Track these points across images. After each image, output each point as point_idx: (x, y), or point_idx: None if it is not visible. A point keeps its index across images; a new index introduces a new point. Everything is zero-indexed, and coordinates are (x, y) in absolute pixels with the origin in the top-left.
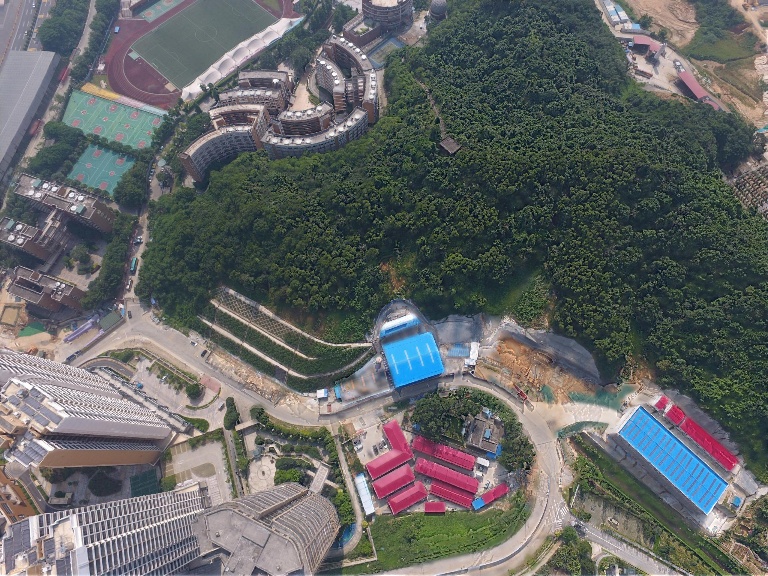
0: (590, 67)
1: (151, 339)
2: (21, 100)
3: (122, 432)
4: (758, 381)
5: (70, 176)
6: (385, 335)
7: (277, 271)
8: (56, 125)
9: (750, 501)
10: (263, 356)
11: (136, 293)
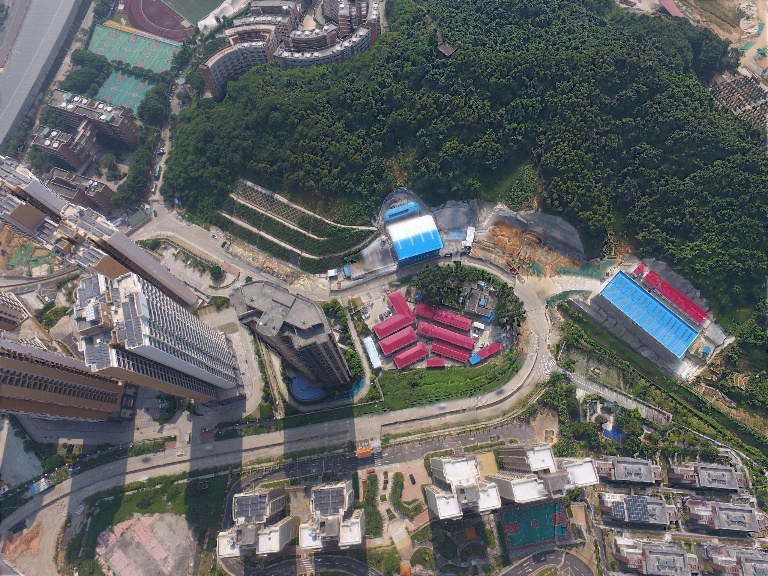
0: None
1: (175, 234)
2: (49, 33)
3: (159, 275)
4: (724, 239)
5: (97, 97)
6: (389, 219)
7: (291, 157)
8: (83, 52)
9: (719, 350)
10: (278, 242)
11: (161, 193)
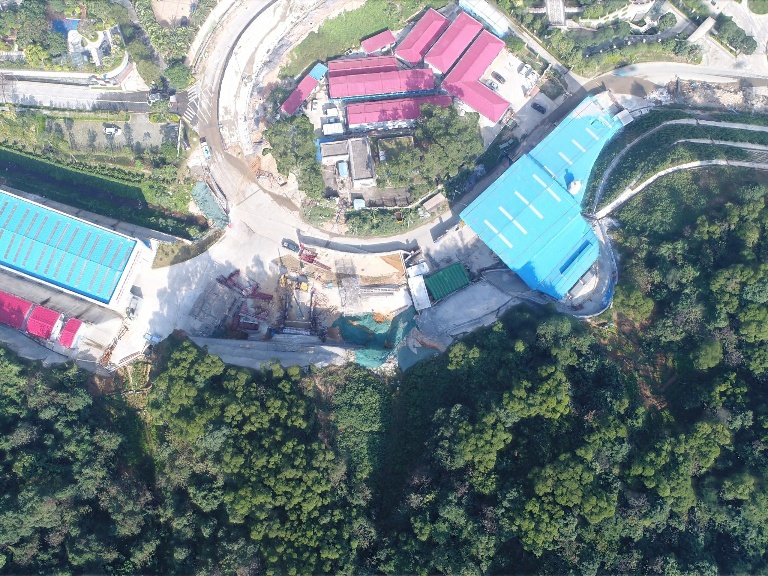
0: None
1: None
2: None
3: None
4: None
5: None
6: (587, 237)
7: None
8: None
9: None
10: (751, 127)
11: None
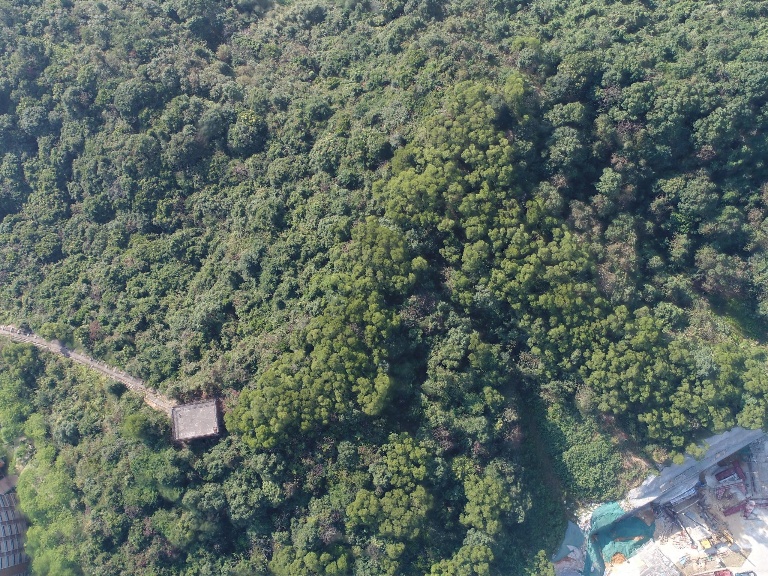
0: (203, 4)
1: None
2: None
3: None
4: None
5: None
6: None
7: None
8: None
9: None
10: None
11: None
